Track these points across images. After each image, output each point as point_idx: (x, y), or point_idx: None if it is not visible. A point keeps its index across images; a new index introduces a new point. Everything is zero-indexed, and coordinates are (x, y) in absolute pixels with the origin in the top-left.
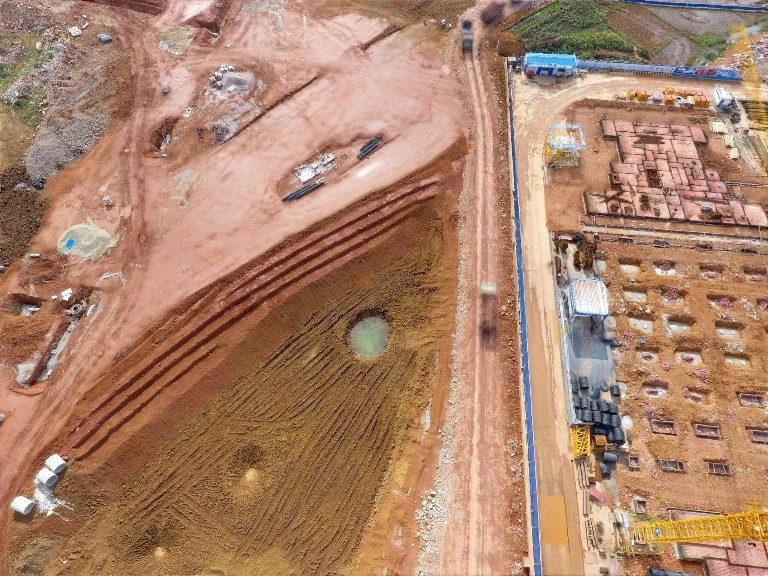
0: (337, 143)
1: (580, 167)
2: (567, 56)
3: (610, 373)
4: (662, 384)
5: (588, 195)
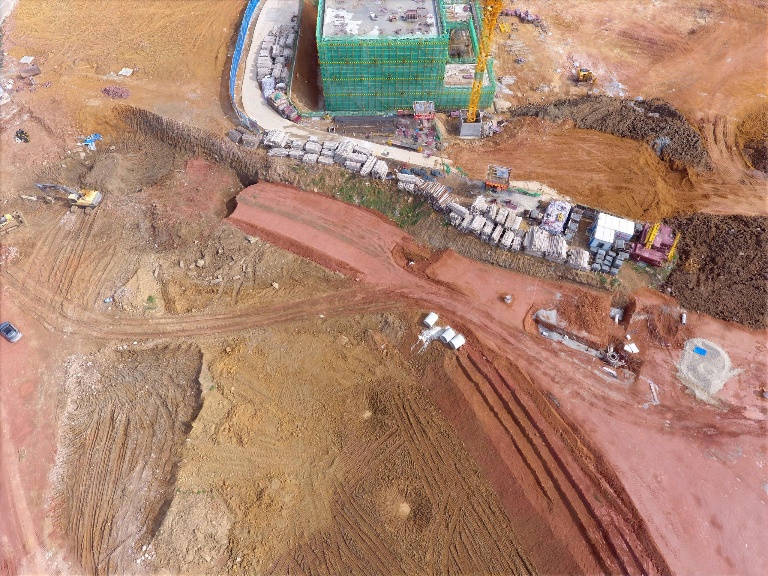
0: None
1: None
2: None
3: None
4: None
5: None
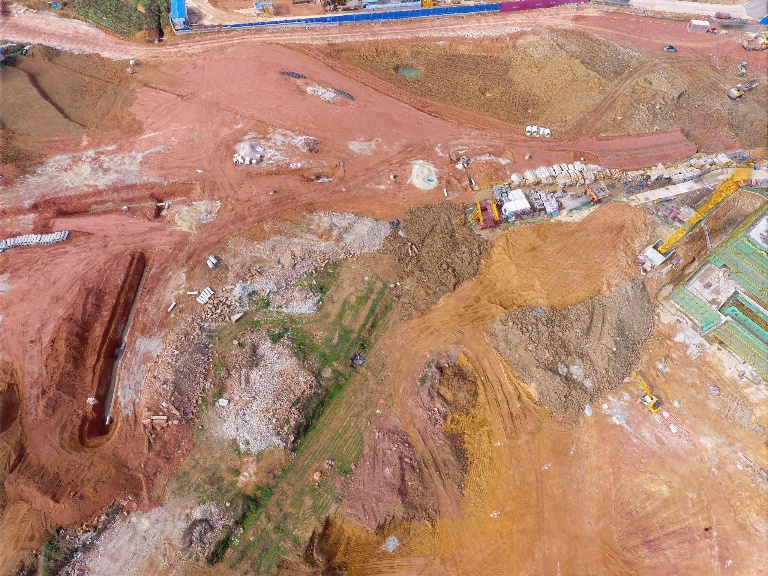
0: (296, 88)
1: (273, 5)
2: (173, 2)
3: None
4: None
5: (295, 1)
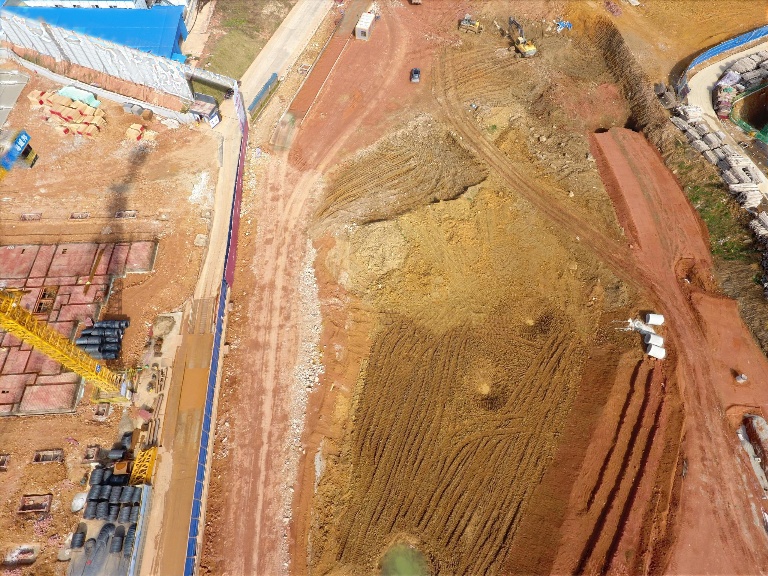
0: None
1: None
2: None
3: (74, 571)
4: (6, 568)
5: None
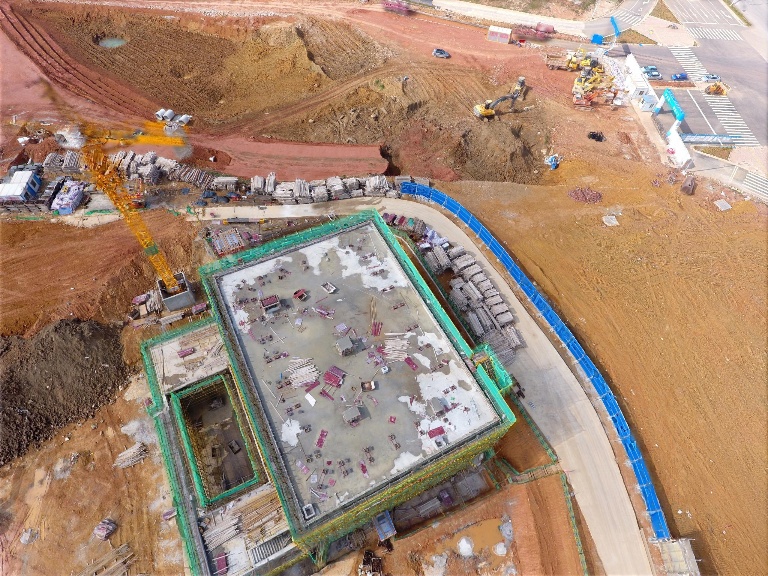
0: None
1: None
2: None
3: None
4: None
5: None
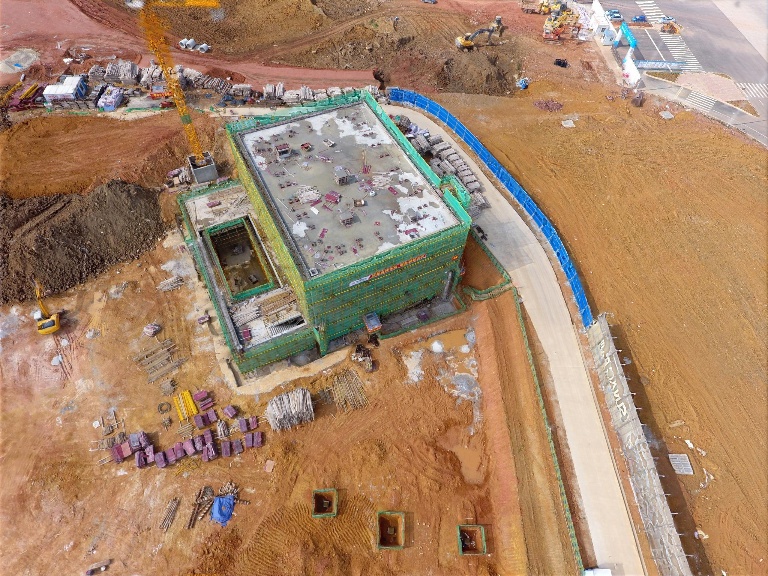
0: None
1: None
2: None
3: None
4: None
5: None
